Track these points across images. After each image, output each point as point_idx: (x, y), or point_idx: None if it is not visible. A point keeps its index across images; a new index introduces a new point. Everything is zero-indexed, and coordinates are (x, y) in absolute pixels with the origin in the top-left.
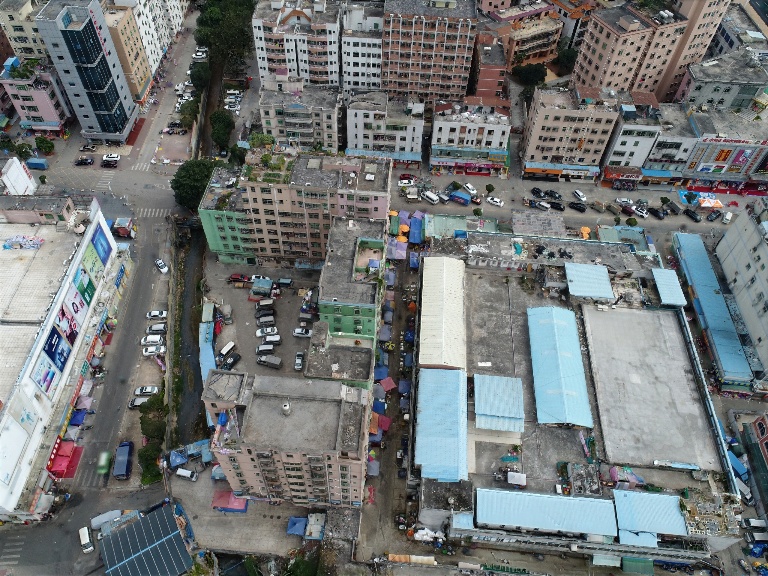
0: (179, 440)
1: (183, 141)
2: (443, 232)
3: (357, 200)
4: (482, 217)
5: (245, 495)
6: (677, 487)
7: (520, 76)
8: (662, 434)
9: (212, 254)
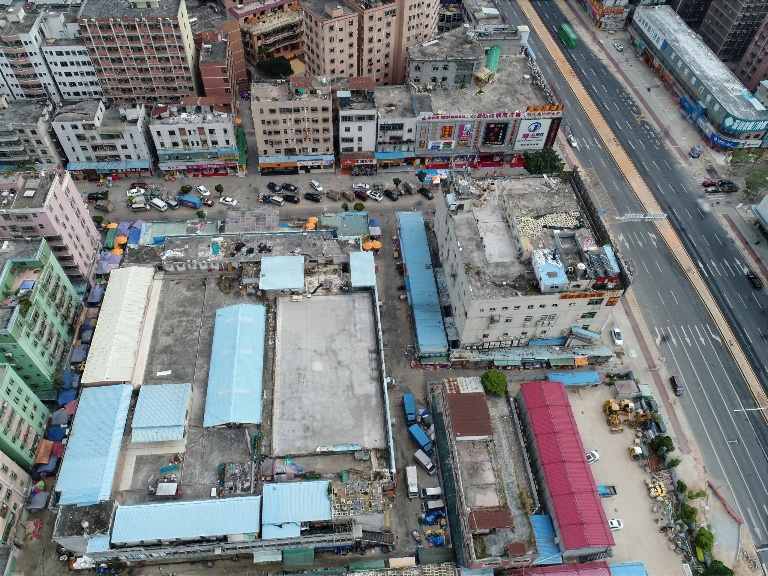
0: None
1: None
2: None
3: (15, 219)
4: (203, 219)
5: None
6: (339, 470)
7: (264, 71)
8: (333, 419)
9: None
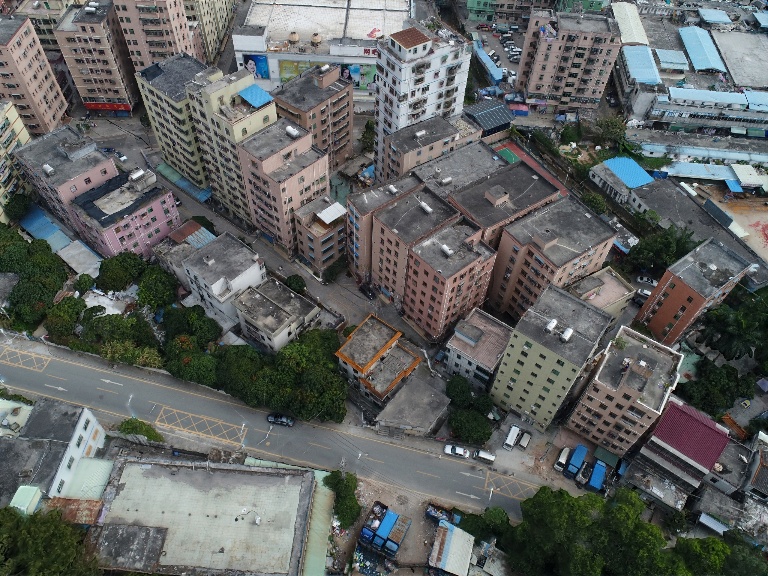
0: None
1: None
2: None
3: None
4: None
5: (533, 98)
6: None
7: None
8: (766, 79)
9: None
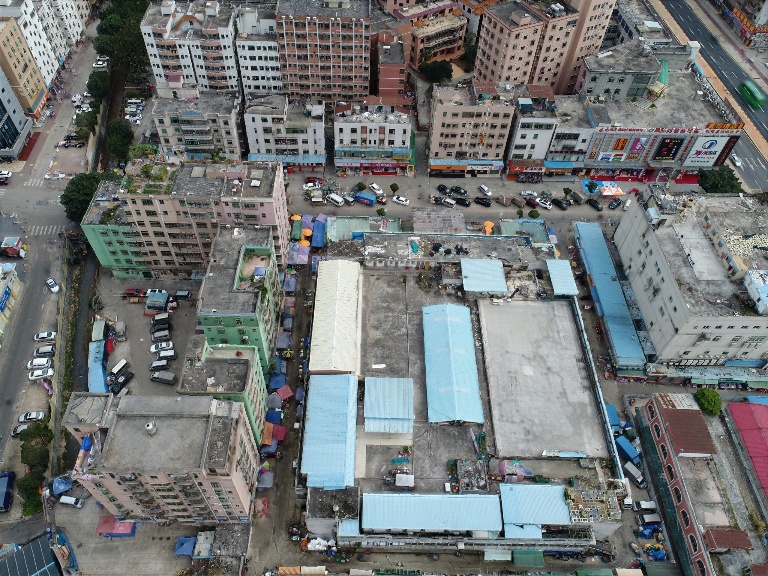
0: (67, 466)
1: (80, 154)
2: (345, 234)
3: (243, 207)
4: (385, 217)
5: (128, 519)
6: (565, 476)
7: (426, 73)
8: (552, 424)
9: (107, 270)
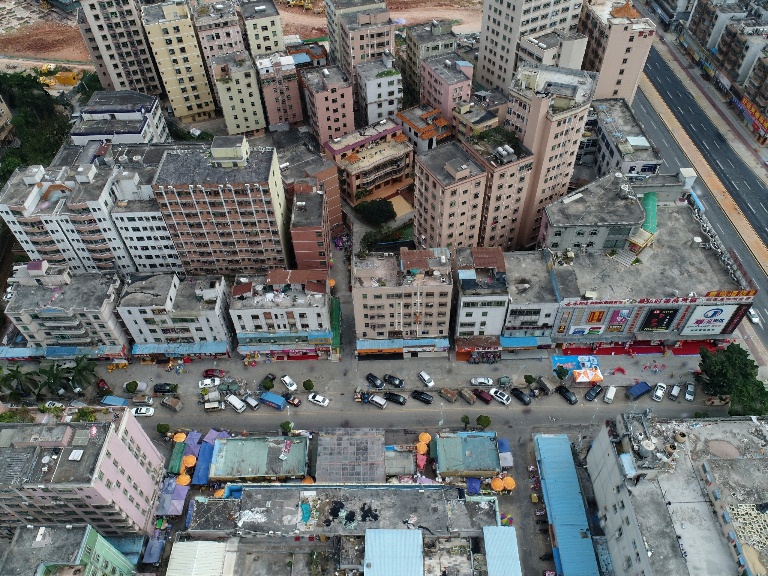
0: None
1: None
2: (235, 466)
3: (56, 492)
4: (288, 437)
5: None
6: None
7: (363, 217)
8: None
9: None
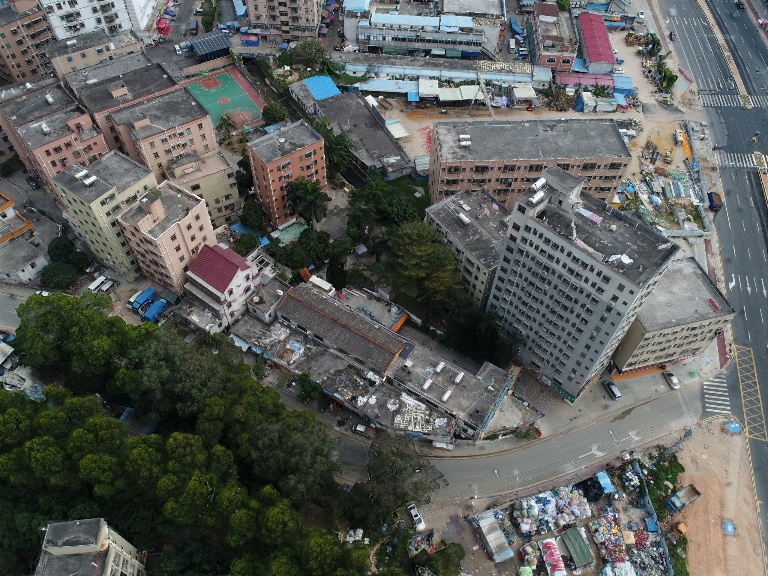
0: None
1: None
2: None
3: None
4: None
5: (257, 28)
6: None
7: None
8: (475, 6)
9: None
